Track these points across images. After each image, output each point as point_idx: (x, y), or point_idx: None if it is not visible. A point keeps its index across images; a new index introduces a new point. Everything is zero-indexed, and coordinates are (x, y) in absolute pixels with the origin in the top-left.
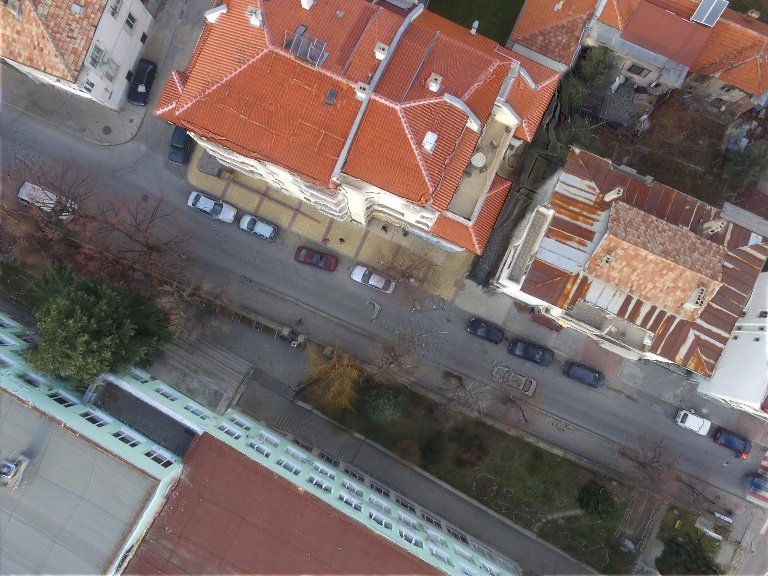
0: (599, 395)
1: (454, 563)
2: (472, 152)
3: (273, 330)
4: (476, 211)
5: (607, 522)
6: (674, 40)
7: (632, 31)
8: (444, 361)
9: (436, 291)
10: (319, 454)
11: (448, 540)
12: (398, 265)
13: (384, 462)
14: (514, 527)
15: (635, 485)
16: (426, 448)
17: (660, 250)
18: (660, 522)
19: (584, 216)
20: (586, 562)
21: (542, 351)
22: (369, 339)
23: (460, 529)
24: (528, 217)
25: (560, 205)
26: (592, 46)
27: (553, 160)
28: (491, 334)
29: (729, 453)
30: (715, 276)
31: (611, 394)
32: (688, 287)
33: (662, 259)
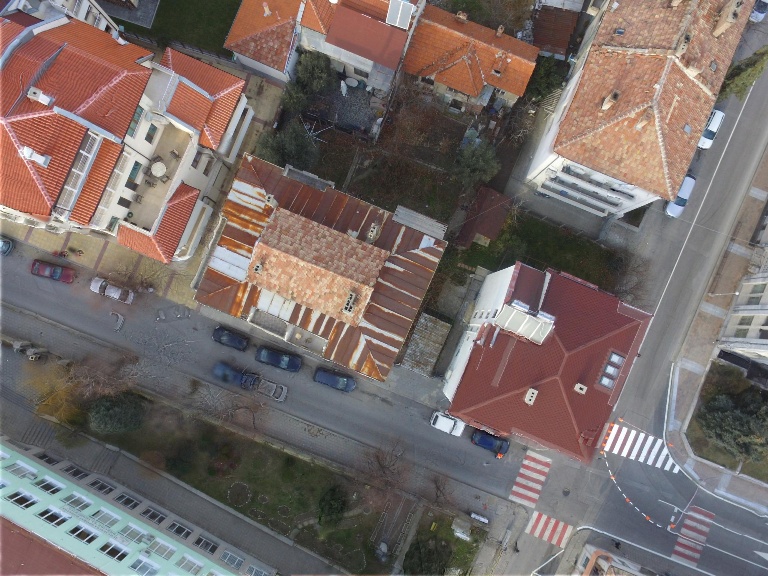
0: (353, 399)
1: (157, 575)
2: (115, 164)
3: (11, 344)
4: (156, 221)
5: (363, 526)
6: (375, 43)
7: (334, 35)
8: (191, 370)
9: (181, 300)
10: (65, 467)
11: (180, 550)
12: (139, 275)
13: (141, 473)
14: (270, 534)
15: (387, 488)
16: (176, 458)
17: (312, 256)
18: (416, 524)
19: (253, 224)
20: (343, 567)
21: (288, 357)
22: (112, 350)
23: (217, 538)
24: (213, 226)
25: (232, 213)
26: (308, 50)
27: (231, 168)
28: (236, 342)
29: (489, 453)
30: (367, 281)
31: (365, 398)
32: (343, 293)
33: (312, 265)
